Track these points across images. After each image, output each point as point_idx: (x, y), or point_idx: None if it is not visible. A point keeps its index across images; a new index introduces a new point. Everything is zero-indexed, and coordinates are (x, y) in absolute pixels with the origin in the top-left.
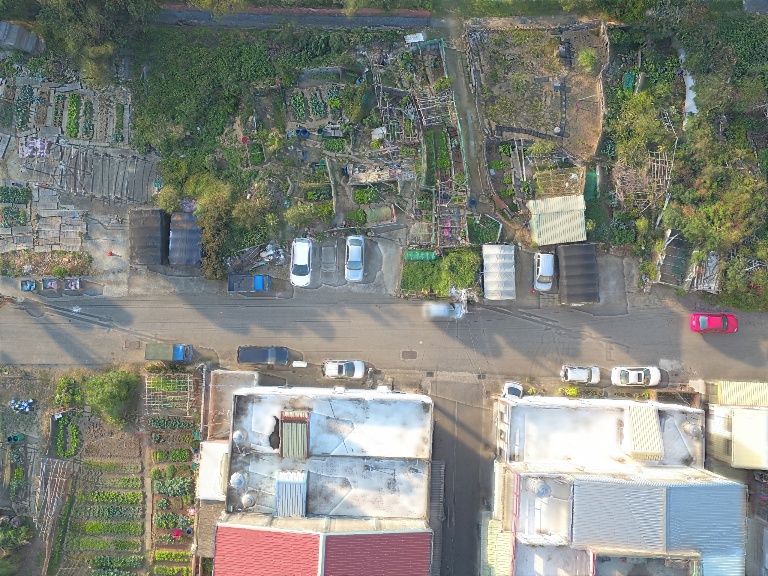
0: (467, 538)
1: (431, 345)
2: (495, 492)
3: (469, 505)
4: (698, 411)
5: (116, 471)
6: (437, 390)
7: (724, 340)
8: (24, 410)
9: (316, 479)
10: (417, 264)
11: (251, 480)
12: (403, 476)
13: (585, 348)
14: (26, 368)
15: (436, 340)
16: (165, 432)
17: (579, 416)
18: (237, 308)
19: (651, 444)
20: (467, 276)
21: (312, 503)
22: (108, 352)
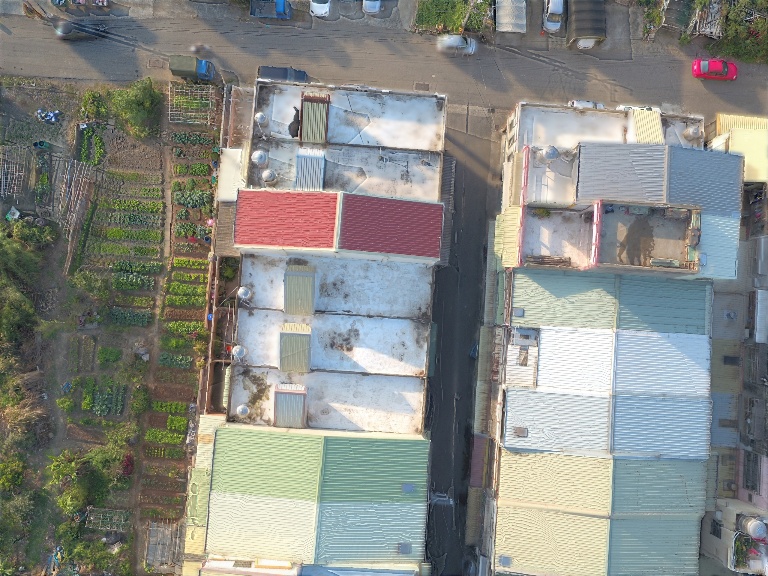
0: (473, 261)
1: (443, 79)
2: (503, 189)
3: (476, 230)
4: (698, 117)
5: (137, 181)
6: (448, 121)
7: (723, 88)
8: (50, 121)
9: (333, 167)
10: (432, 1)
11: (270, 165)
12: (416, 168)
13: (590, 89)
14: (53, 81)
15: (448, 74)
16: (186, 147)
17: (585, 121)
18: (258, 35)
19: (653, 139)
20: (480, 8)
21: (328, 189)
22: (132, 69)
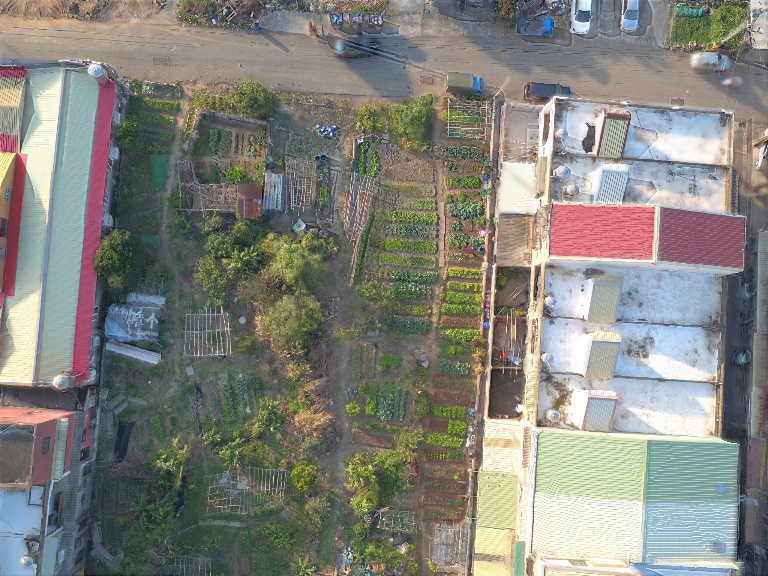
0: None
1: (697, 94)
2: None
3: None
4: None
5: (412, 194)
6: None
7: None
8: (327, 135)
9: None
10: (685, 19)
11: (566, 179)
12: (703, 182)
13: None
14: (329, 97)
15: (701, 90)
16: (456, 161)
17: None
18: (520, 52)
19: None
20: (737, 26)
21: None
22: (404, 86)
